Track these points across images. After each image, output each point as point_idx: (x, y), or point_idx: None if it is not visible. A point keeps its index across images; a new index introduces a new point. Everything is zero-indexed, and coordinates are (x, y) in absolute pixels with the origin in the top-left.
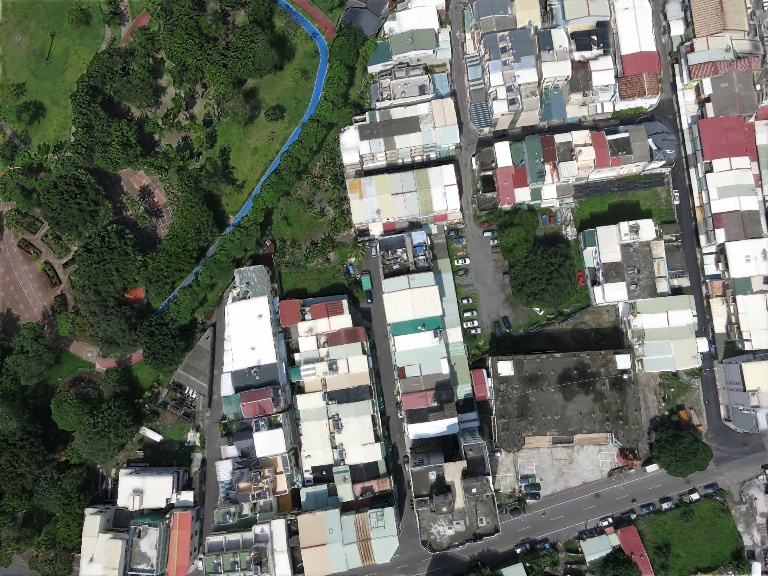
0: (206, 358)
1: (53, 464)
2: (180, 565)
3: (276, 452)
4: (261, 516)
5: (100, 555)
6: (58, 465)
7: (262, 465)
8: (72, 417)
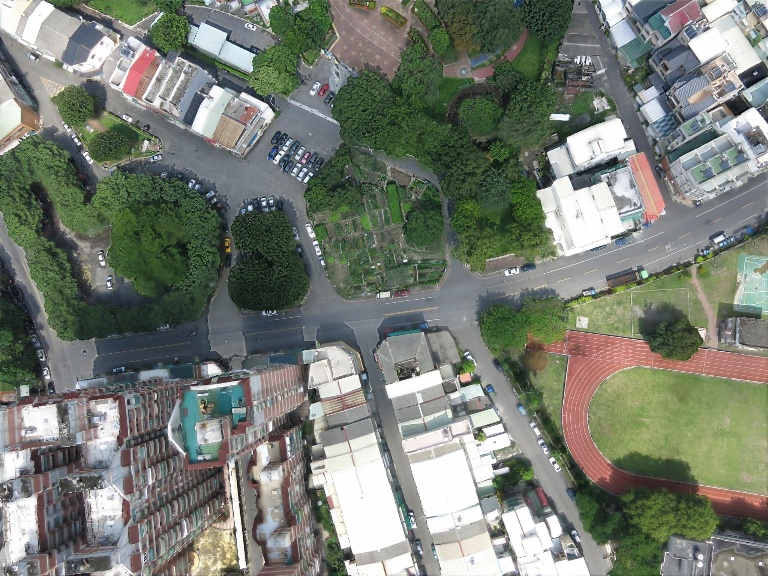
0: (586, 22)
1: (489, 161)
2: (656, 201)
3: (717, 52)
4: (722, 122)
5: (587, 206)
6: (492, 164)
7: (705, 73)
8: (489, 113)
